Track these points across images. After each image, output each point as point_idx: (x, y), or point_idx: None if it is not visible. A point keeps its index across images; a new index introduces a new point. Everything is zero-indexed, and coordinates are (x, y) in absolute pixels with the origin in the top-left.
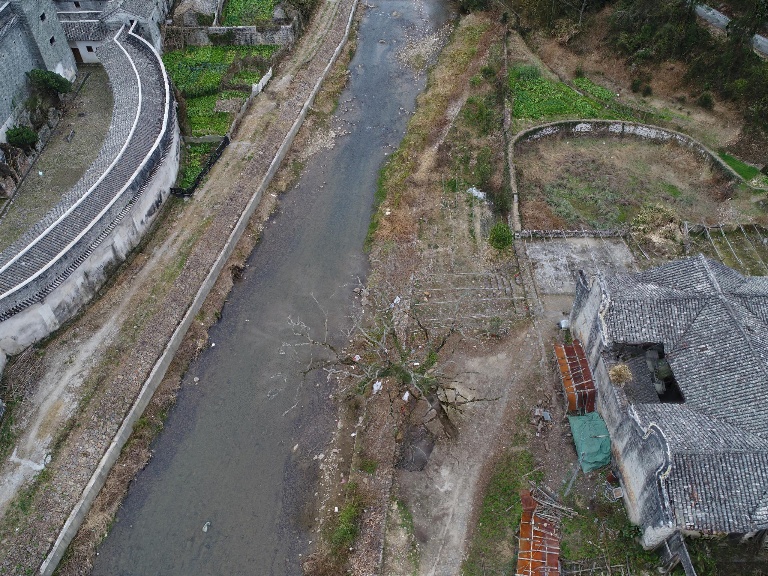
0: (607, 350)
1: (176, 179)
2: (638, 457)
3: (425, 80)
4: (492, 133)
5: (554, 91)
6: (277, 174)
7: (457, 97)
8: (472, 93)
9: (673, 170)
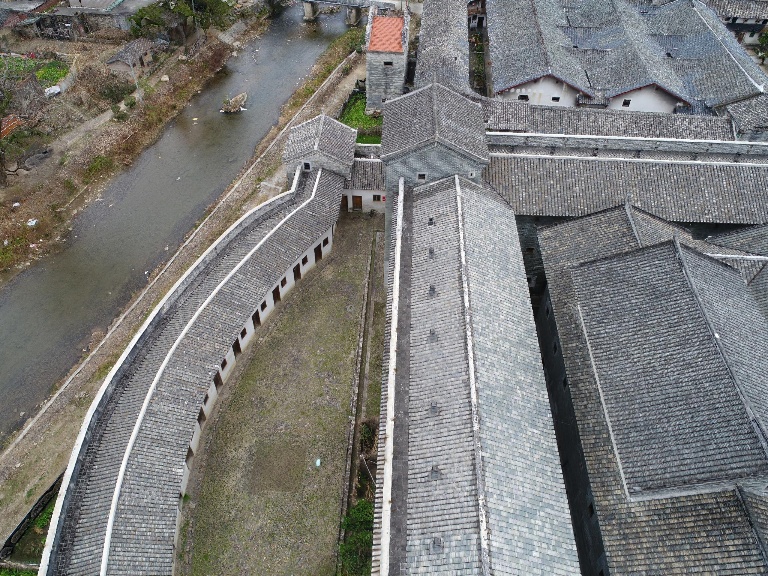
0: None
1: None
2: None
3: None
4: None
5: None
6: None
7: None
8: None
9: None
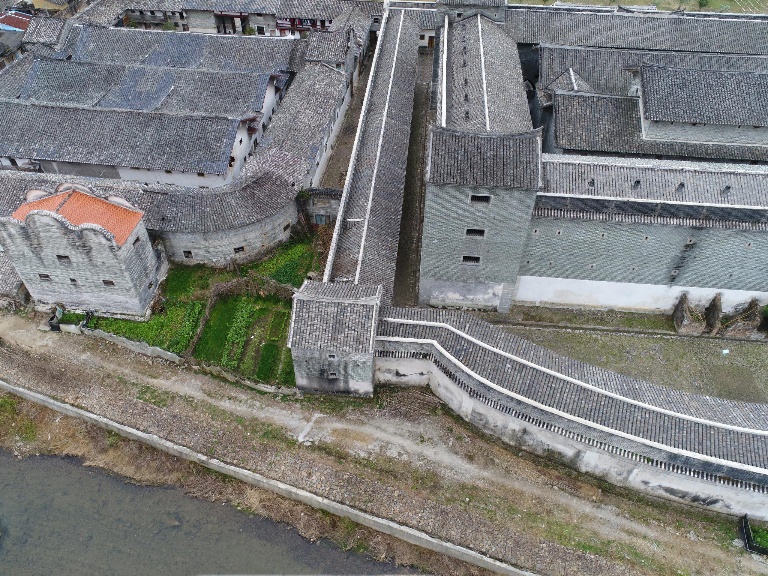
0: None
1: None
2: None
3: None
4: None
5: None
6: None
7: None
8: None
9: None
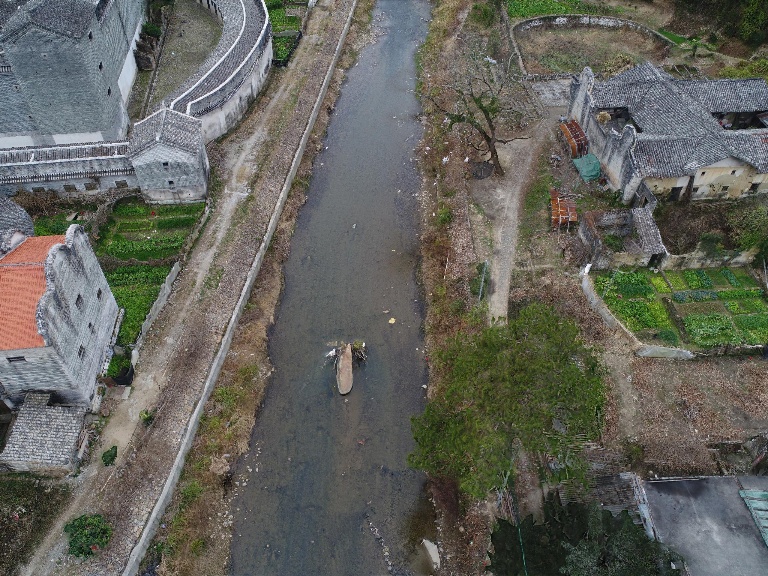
0: (594, 111)
1: (273, 56)
2: (617, 153)
3: (435, 0)
4: (495, 26)
5: (536, 0)
6: (340, 58)
7: (463, 8)
8: (475, 4)
9: (627, 45)
